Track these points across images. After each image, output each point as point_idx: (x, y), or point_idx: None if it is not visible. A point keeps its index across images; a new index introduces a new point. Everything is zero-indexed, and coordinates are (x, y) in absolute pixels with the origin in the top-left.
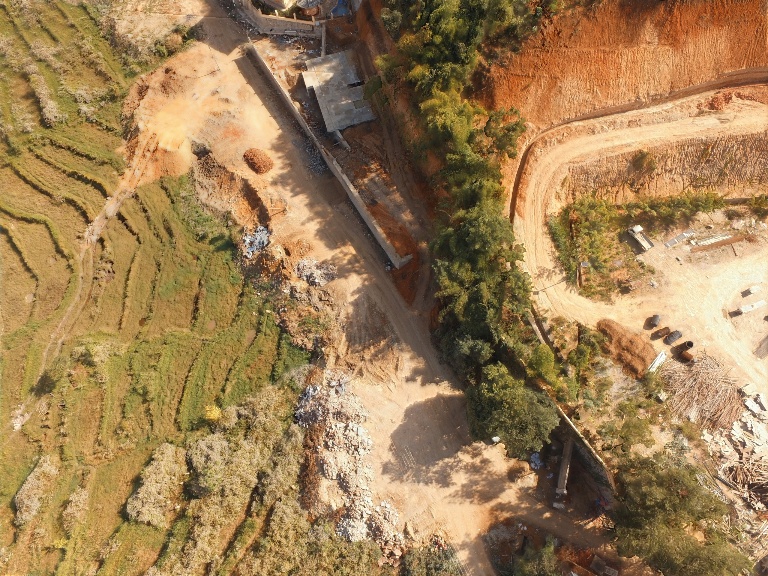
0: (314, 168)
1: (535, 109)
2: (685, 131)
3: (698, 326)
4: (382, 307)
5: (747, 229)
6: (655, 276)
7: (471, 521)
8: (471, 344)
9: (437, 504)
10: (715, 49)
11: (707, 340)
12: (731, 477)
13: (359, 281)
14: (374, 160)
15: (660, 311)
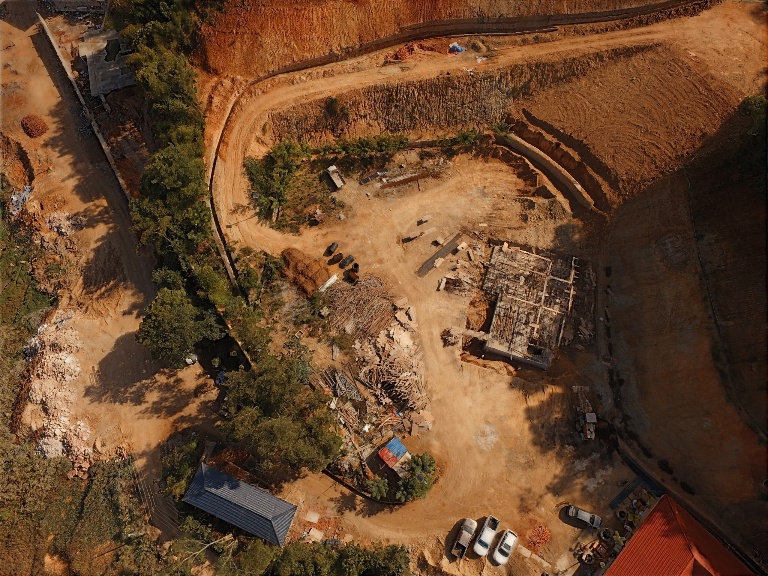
0: (84, 131)
1: (243, 63)
2: (370, 79)
3: (372, 251)
4: (118, 252)
5: (434, 167)
6: (344, 210)
7: (154, 433)
8: (164, 274)
9: (127, 420)
10: (393, 5)
11: (377, 263)
12: (369, 378)
13: (105, 230)
14: (130, 120)
15: (341, 240)
